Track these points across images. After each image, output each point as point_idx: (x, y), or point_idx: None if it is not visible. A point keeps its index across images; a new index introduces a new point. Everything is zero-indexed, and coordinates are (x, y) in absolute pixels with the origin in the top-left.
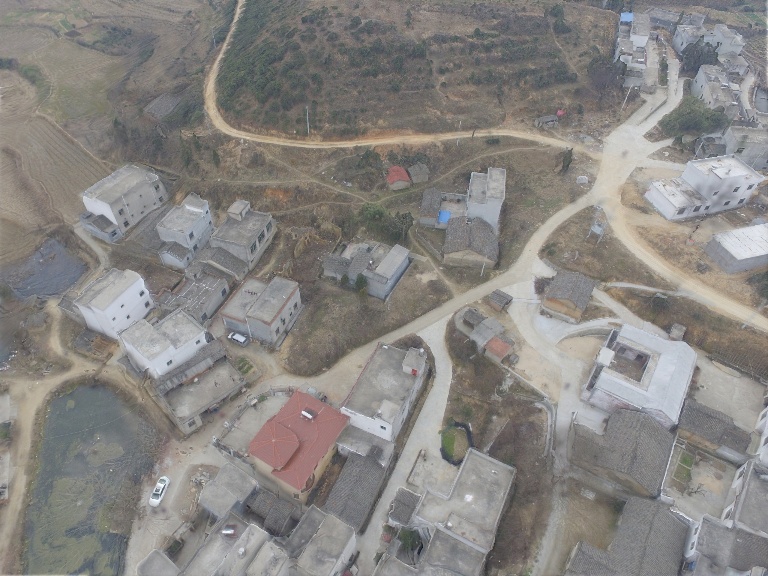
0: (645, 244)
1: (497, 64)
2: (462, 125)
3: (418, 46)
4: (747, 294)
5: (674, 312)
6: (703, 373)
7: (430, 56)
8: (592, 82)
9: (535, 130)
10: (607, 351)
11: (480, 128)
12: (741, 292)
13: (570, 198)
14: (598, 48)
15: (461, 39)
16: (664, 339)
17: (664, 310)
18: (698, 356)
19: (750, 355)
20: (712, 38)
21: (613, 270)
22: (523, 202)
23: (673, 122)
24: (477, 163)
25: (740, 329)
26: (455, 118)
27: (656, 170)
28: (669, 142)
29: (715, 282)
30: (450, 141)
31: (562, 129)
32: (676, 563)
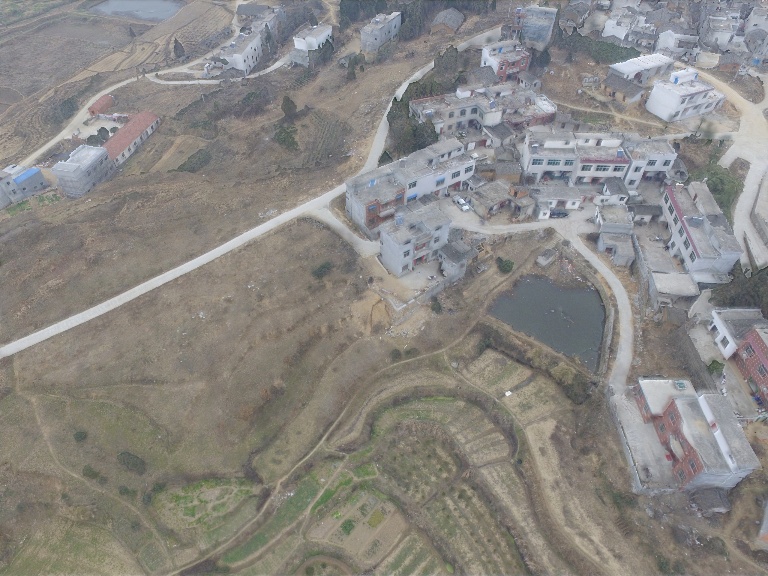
0: None
1: None
2: None
3: None
4: None
5: None
6: None
7: None
8: None
9: None
10: (697, 51)
11: None
12: None
13: None
14: None
15: None
16: (674, 53)
17: None
18: None
19: None
20: None
21: None
22: None
23: None
24: None
25: None
26: None
27: (721, 130)
28: None
29: None
30: None
31: None
32: (647, 19)
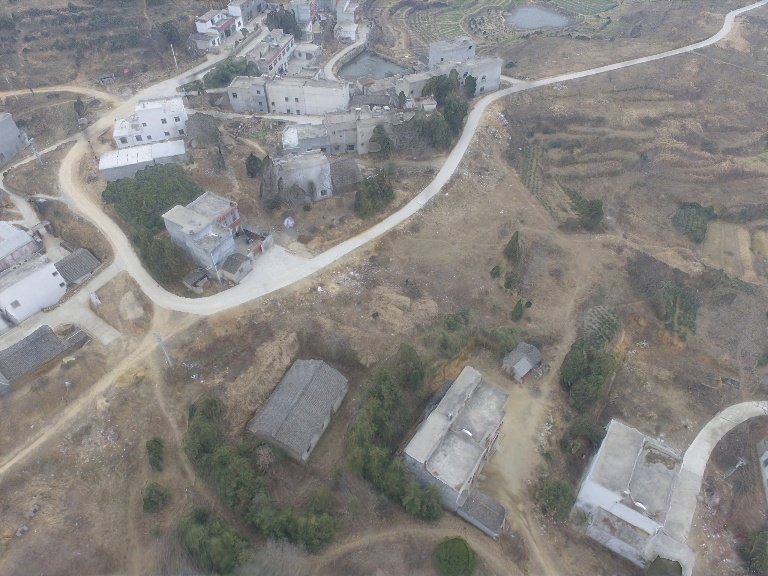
0: (77, 166)
1: (82, 32)
2: (31, 83)
3: (2, 18)
4: (100, 196)
5: (50, 212)
6: (46, 255)
7: (20, 27)
8: (159, 45)
9: (94, 86)
10: None
11: (49, 86)
12: (99, 195)
13: (66, 136)
14: (188, 17)
15: (52, 12)
16: None
17: (46, 211)
18: (55, 244)
19: (77, 239)
20: (309, 7)
21: (36, 185)
22: (41, 142)
23: (209, 76)
24: (30, 113)
25: (75, 220)
26: (28, 78)
27: None
28: (200, 92)
29: (91, 189)
30: (14, 96)
31: (117, 84)
32: None
